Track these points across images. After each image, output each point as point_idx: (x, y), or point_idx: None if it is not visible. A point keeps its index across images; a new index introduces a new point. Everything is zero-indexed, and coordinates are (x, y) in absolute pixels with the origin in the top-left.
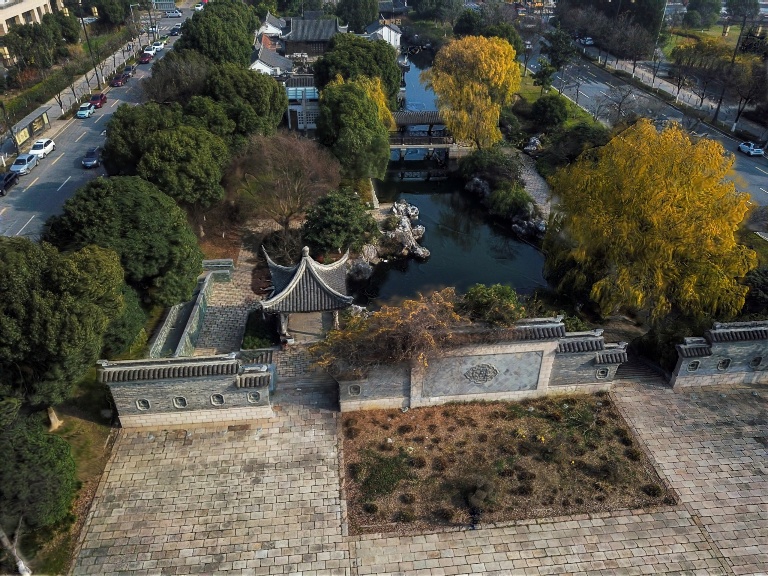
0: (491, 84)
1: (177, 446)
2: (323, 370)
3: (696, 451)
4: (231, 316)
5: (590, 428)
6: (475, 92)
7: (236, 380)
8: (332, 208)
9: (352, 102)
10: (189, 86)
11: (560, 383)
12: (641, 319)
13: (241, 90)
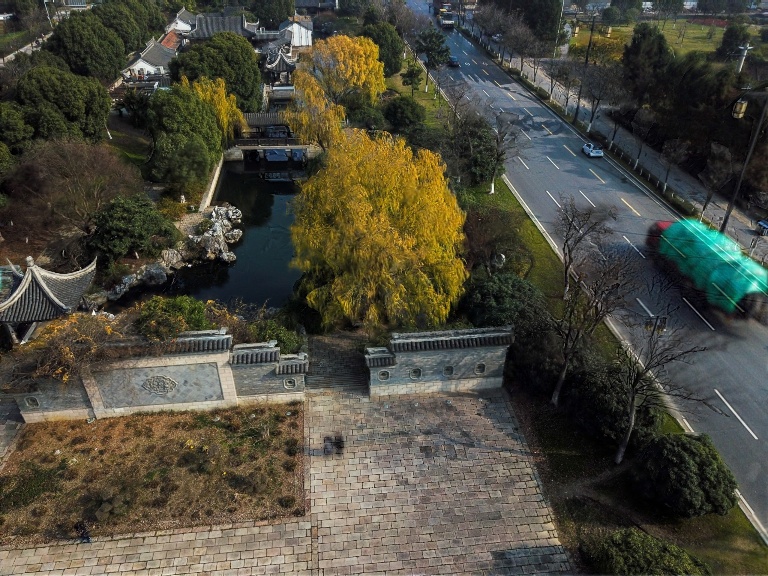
0: (351, 85)
1: None
2: None
3: (356, 461)
4: None
5: (263, 438)
6: (315, 94)
7: None
8: (114, 214)
9: (174, 105)
10: (9, 90)
11: (249, 393)
12: (394, 325)
13: (48, 94)
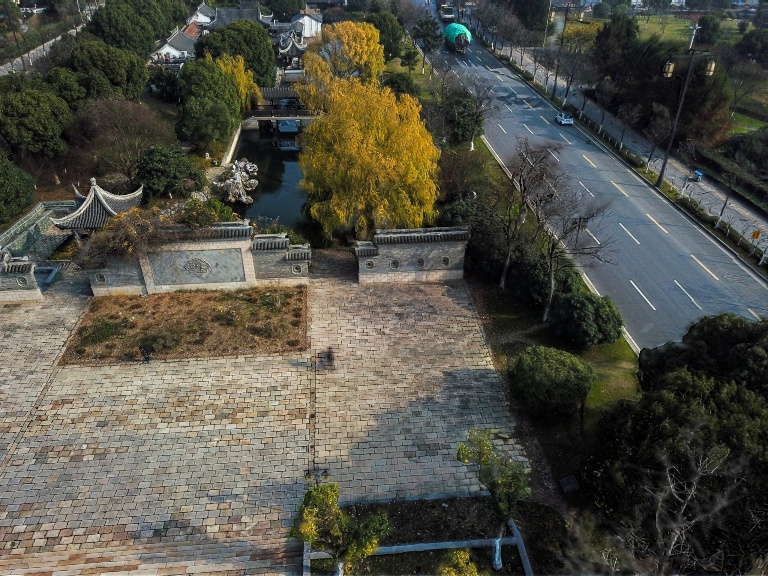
0: (354, 64)
1: None
2: None
3: (346, 321)
4: (58, 241)
5: (276, 307)
6: (321, 68)
7: (4, 267)
8: (154, 158)
9: (201, 75)
10: (62, 61)
11: (265, 277)
12: None
13: (97, 63)
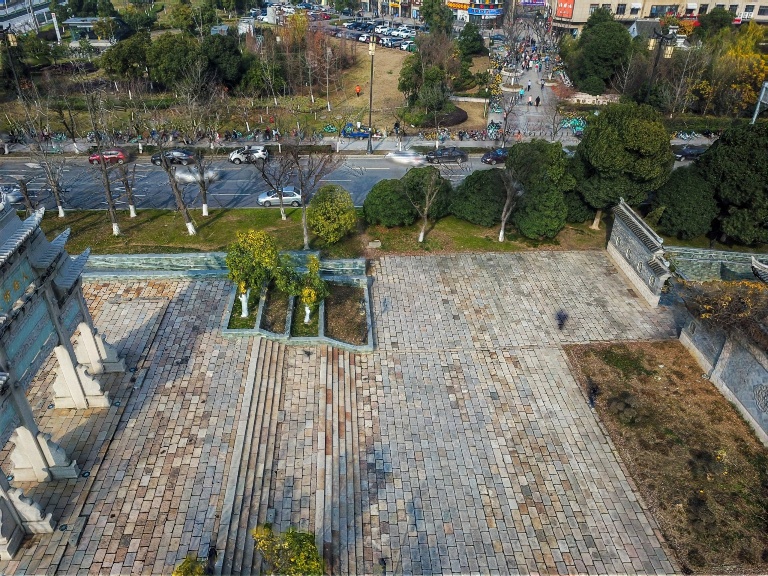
0: None
1: (602, 271)
2: (683, 288)
3: None
4: None
5: None
6: None
7: (652, 259)
8: None
9: None
10: None
11: None
12: None
13: None
